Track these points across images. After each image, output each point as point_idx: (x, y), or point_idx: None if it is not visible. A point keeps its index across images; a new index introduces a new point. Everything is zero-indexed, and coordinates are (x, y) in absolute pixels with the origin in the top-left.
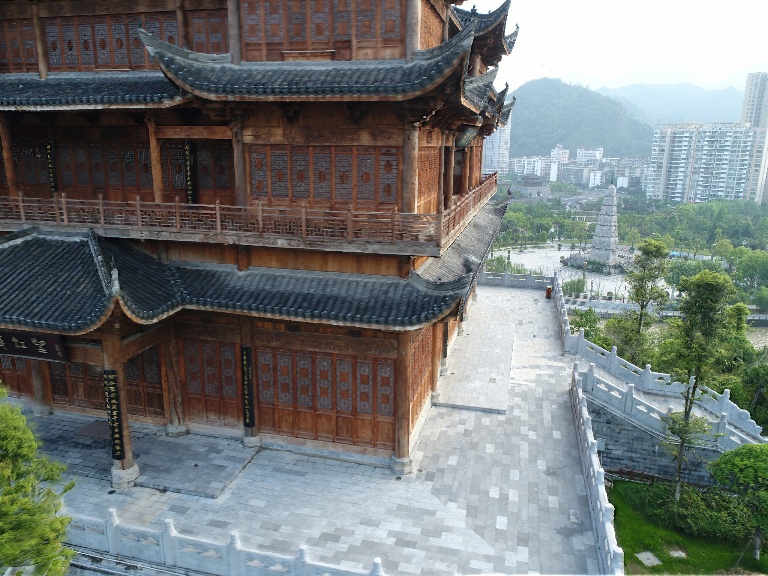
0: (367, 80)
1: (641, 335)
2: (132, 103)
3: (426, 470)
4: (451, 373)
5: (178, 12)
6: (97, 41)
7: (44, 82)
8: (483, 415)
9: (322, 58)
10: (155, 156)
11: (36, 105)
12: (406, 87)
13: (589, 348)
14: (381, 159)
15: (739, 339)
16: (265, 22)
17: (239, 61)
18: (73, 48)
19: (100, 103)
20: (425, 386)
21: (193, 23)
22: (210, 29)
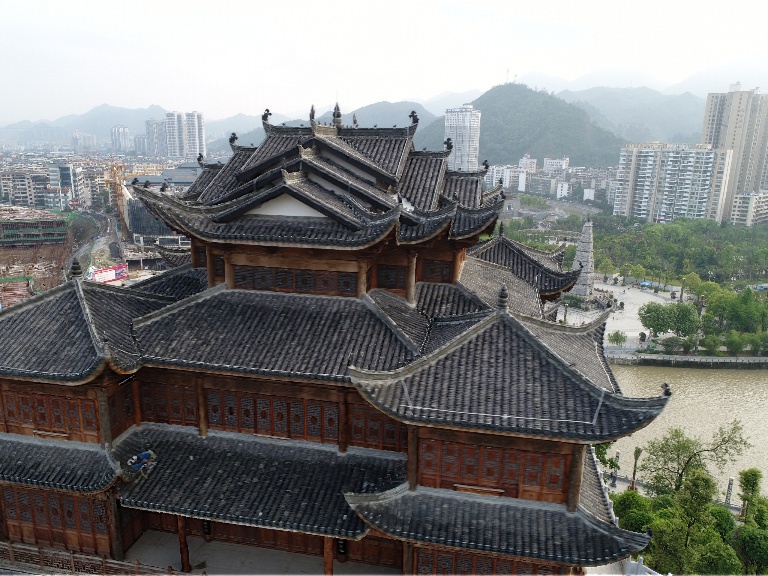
0: (540, 535)
1: (688, 549)
2: (327, 534)
3: None
4: None
5: (341, 405)
6: (258, 411)
7: (209, 447)
8: None
9: (491, 494)
10: (329, 545)
11: (232, 520)
12: (581, 562)
13: (647, 573)
14: (538, 572)
15: (767, 539)
16: (441, 460)
17: (415, 487)
18: (234, 413)
19: (296, 529)
20: None
21: (353, 411)
22: (369, 418)
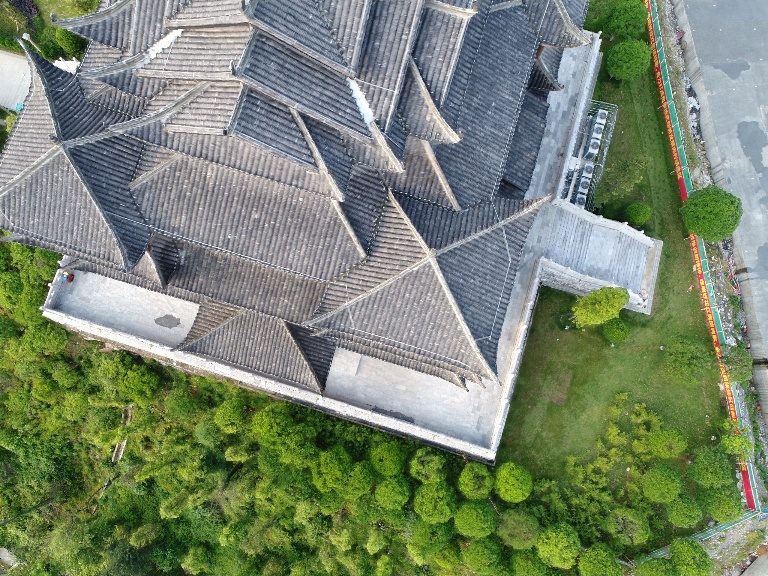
0: None
1: None
2: None
3: None
4: None
5: None
6: None
7: None
8: None
9: None
10: None
11: None
12: None
13: None
14: None
15: None
16: None
17: None
18: None
19: None
20: None
21: None
22: None
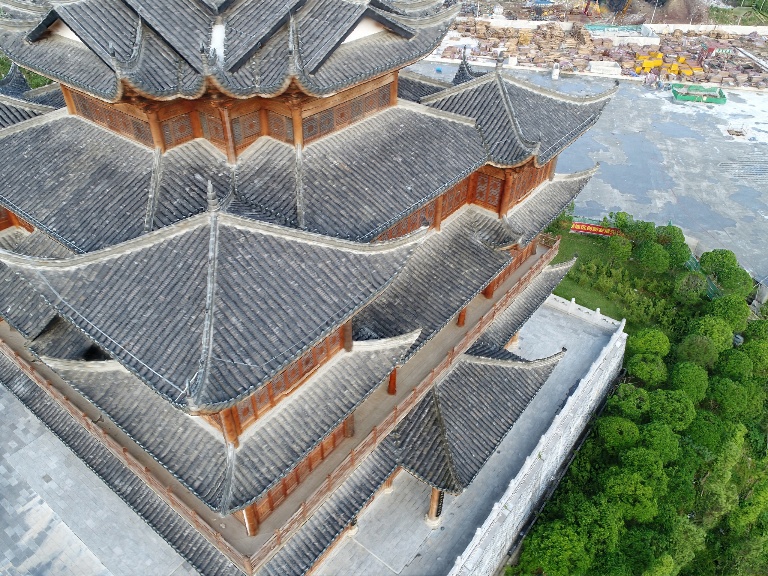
0: None
1: None
2: None
3: (6, 392)
4: None
5: None
6: None
7: None
8: (20, 447)
9: None
10: None
11: None
12: None
13: None
14: None
15: None
16: None
17: None
18: None
19: None
20: None
21: None
22: None
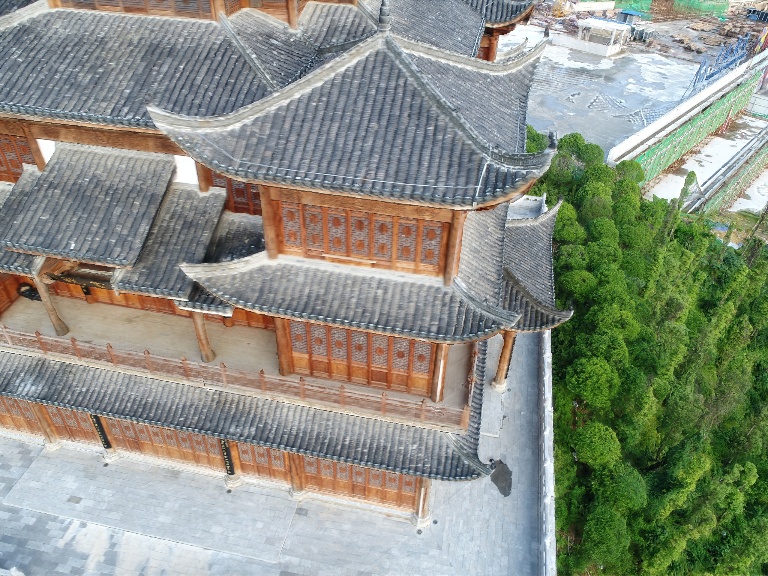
0: None
1: None
2: None
3: None
4: (107, 463)
5: None
6: None
7: None
8: (10, 484)
9: None
10: None
11: None
12: None
13: None
14: None
15: None
16: None
17: None
18: None
19: None
20: (21, 423)
21: None
22: None
